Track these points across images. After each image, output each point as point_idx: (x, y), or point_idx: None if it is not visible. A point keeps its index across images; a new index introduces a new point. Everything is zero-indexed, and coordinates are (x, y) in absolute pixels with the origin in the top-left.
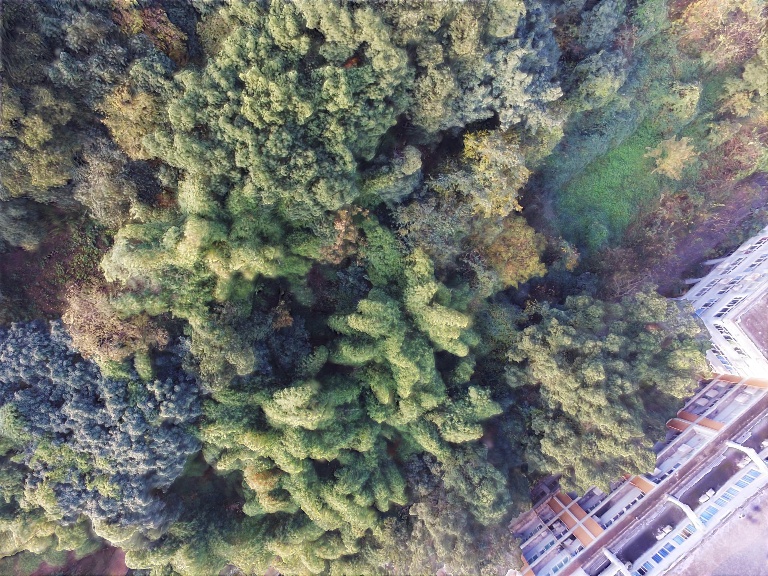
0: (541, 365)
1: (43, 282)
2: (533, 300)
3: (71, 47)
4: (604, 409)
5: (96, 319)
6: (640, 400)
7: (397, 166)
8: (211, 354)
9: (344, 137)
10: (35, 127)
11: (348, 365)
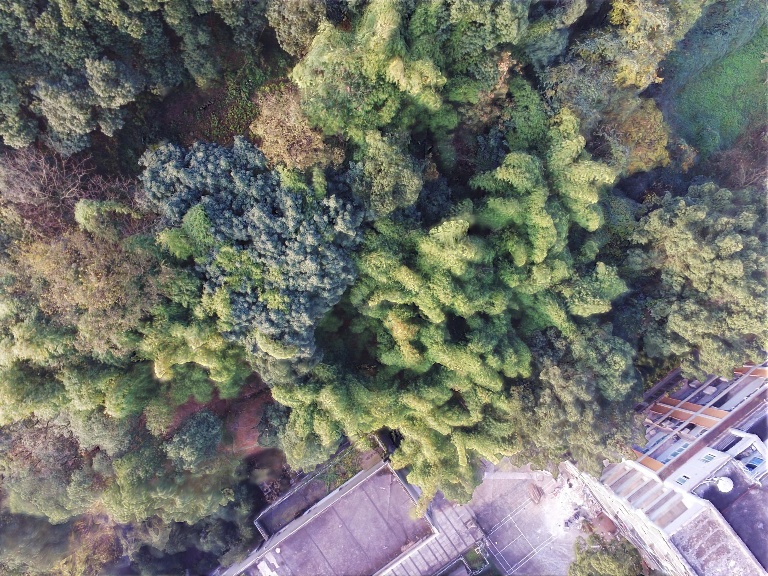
0: (675, 237)
1: (197, 132)
2: None
3: None
4: (740, 281)
5: (289, 121)
6: None
7: (558, 14)
8: (388, 169)
9: None
10: None
11: (488, 224)
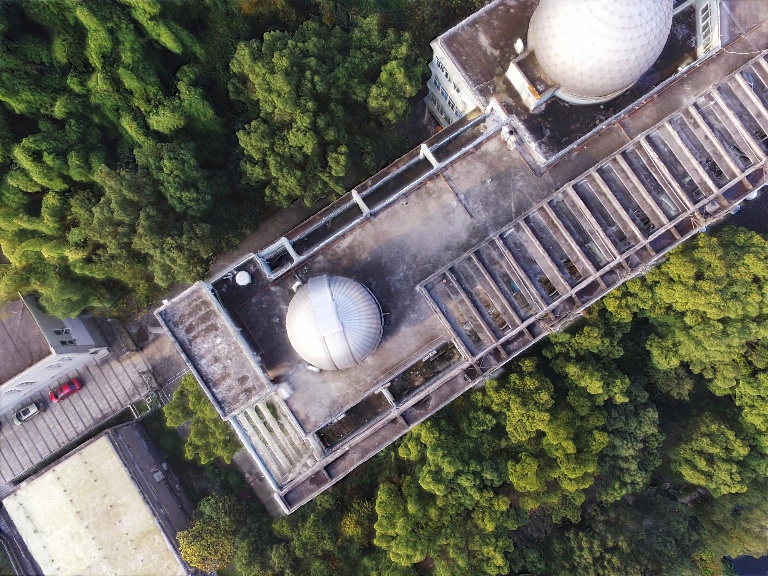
0: (237, 54)
1: None
2: None
3: None
4: (286, 94)
5: None
6: (338, 107)
7: None
8: None
9: None
10: None
11: (46, 26)
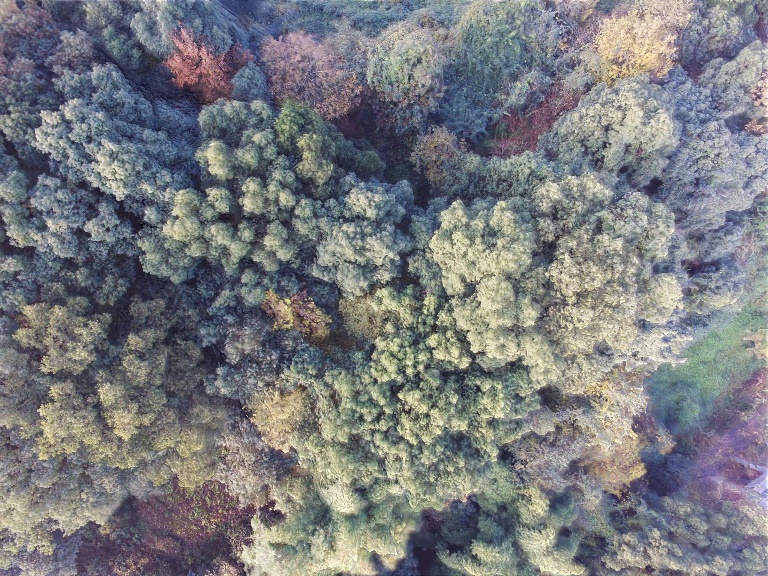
0: None
1: (151, 499)
2: (627, 493)
3: (228, 361)
4: None
5: None
6: None
7: (526, 424)
8: None
9: (493, 438)
10: (188, 440)
11: None
